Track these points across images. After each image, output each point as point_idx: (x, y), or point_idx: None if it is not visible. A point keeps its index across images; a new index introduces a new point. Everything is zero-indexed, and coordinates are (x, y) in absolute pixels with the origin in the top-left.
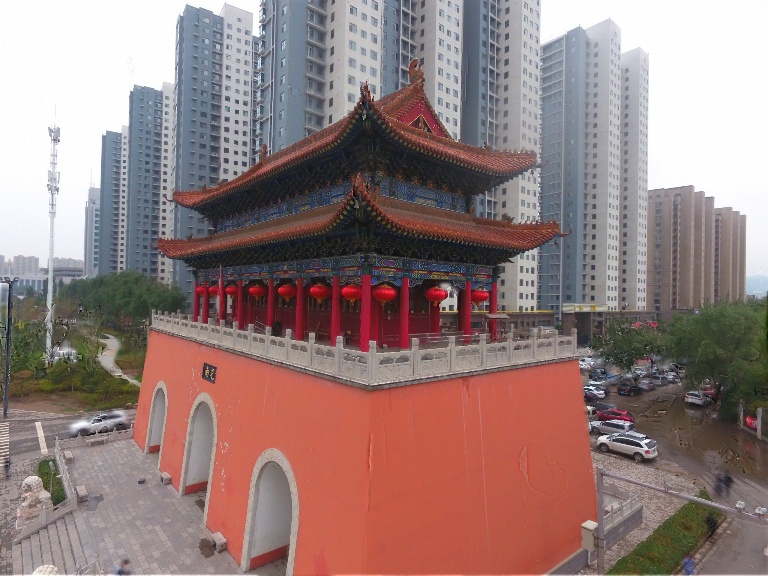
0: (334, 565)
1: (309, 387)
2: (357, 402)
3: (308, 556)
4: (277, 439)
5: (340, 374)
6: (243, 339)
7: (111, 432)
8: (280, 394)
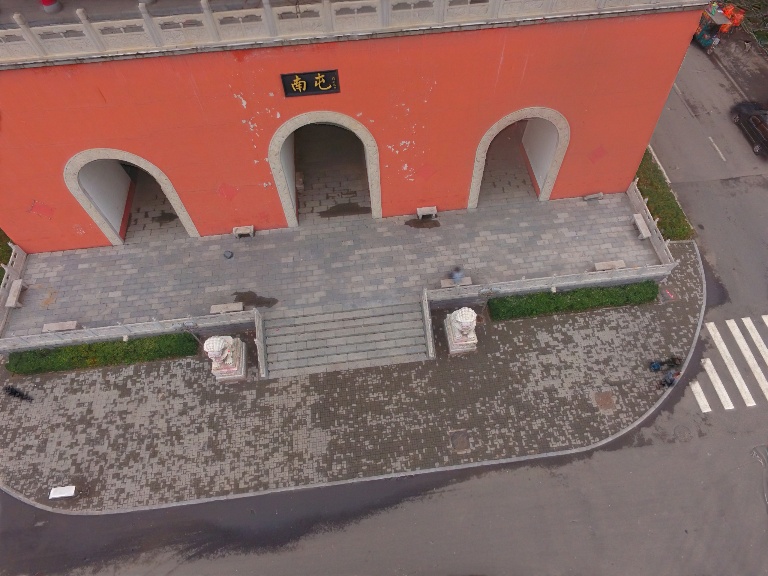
0: (615, 146)
1: (603, 31)
2: (682, 24)
3: (581, 156)
4: (530, 99)
5: (661, 4)
6: (417, 9)
7: (5, 273)
8: (536, 55)
